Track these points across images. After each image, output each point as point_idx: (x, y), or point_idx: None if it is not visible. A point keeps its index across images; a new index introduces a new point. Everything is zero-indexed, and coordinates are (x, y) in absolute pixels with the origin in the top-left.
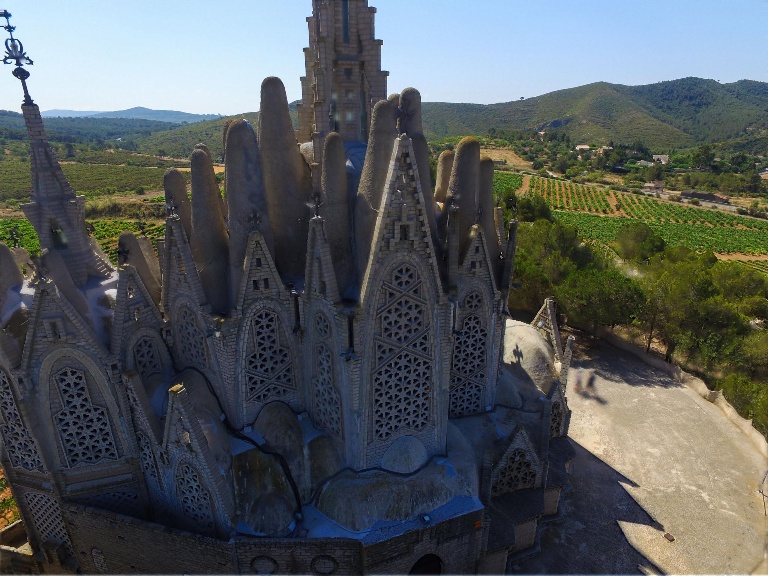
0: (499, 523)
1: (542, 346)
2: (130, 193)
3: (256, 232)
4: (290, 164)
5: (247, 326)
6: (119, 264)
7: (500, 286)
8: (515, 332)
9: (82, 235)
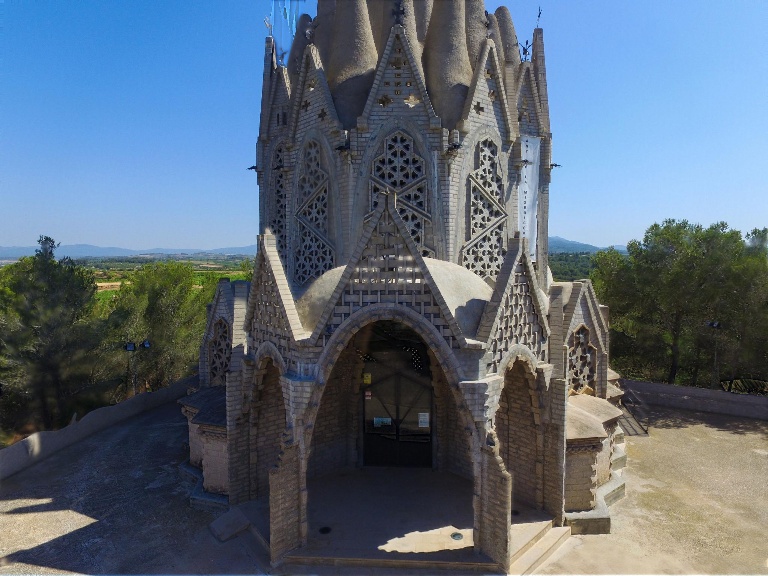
0: None
1: (331, 281)
2: None
3: None
4: None
5: None
6: None
7: None
8: None
9: None
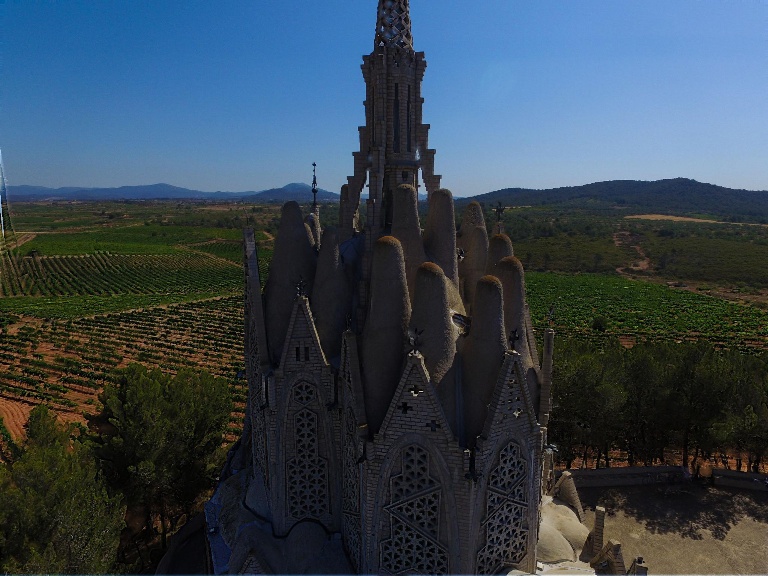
0: None
1: None
2: None
3: None
4: None
5: None
6: None
7: None
8: None
9: None
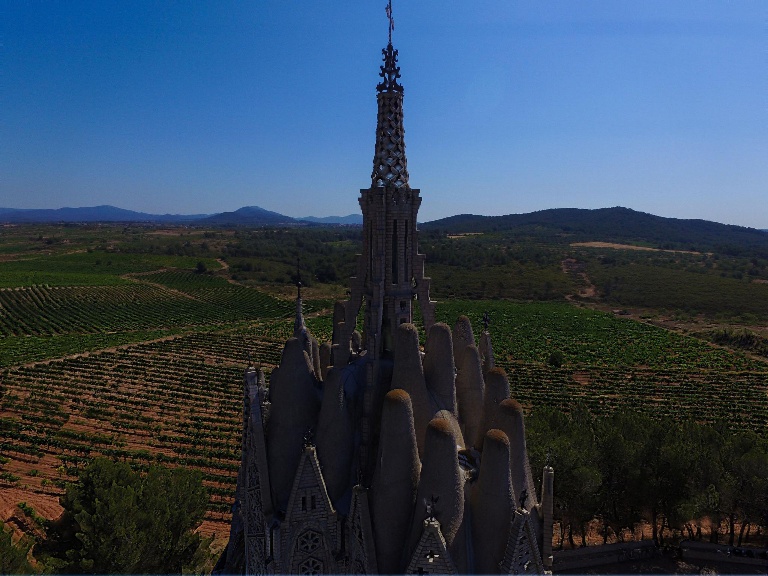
0: None
1: None
2: None
3: None
4: None
5: None
6: None
7: None
8: None
9: None
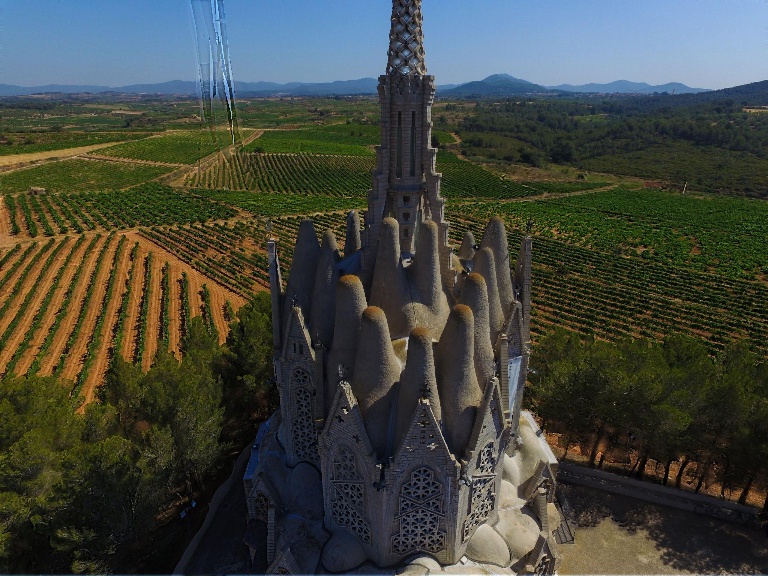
0: (260, 533)
1: None
2: None
3: None
4: None
5: None
6: None
7: None
8: (413, 575)
9: None
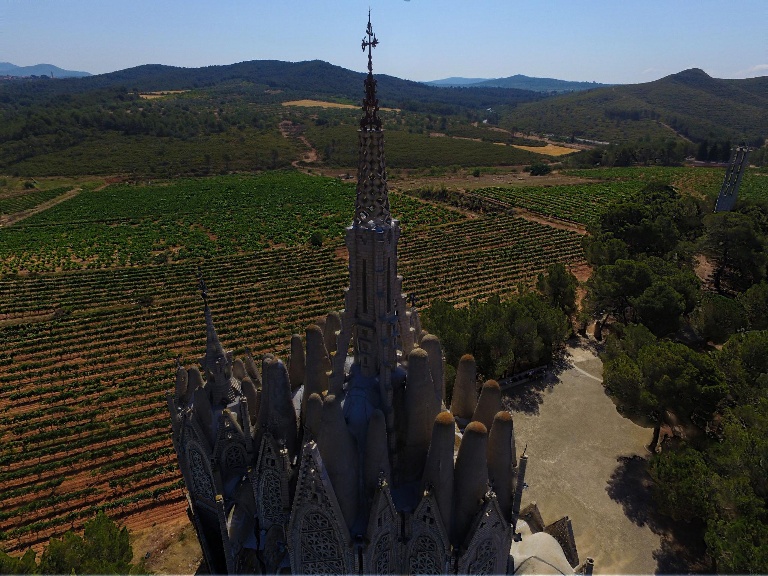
0: None
1: None
2: (468, 174)
3: (266, 435)
4: (318, 383)
5: (264, 479)
6: (240, 394)
7: (462, 542)
8: (536, 569)
9: (224, 376)
